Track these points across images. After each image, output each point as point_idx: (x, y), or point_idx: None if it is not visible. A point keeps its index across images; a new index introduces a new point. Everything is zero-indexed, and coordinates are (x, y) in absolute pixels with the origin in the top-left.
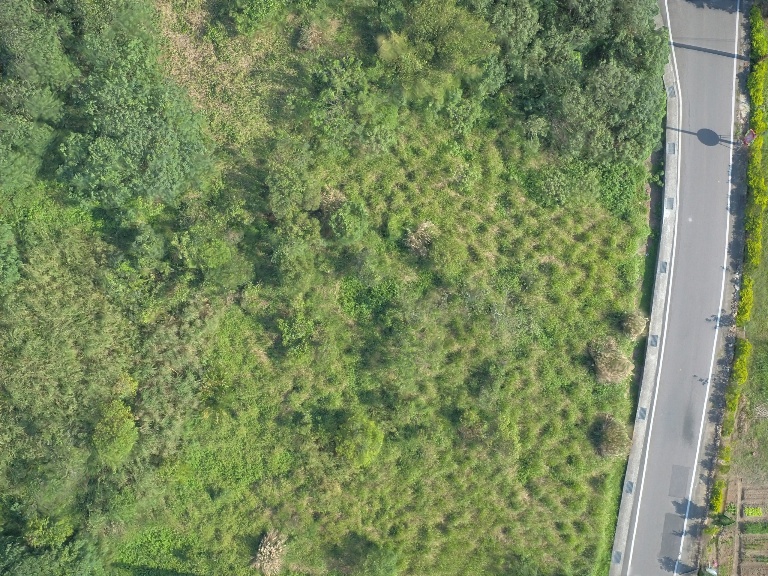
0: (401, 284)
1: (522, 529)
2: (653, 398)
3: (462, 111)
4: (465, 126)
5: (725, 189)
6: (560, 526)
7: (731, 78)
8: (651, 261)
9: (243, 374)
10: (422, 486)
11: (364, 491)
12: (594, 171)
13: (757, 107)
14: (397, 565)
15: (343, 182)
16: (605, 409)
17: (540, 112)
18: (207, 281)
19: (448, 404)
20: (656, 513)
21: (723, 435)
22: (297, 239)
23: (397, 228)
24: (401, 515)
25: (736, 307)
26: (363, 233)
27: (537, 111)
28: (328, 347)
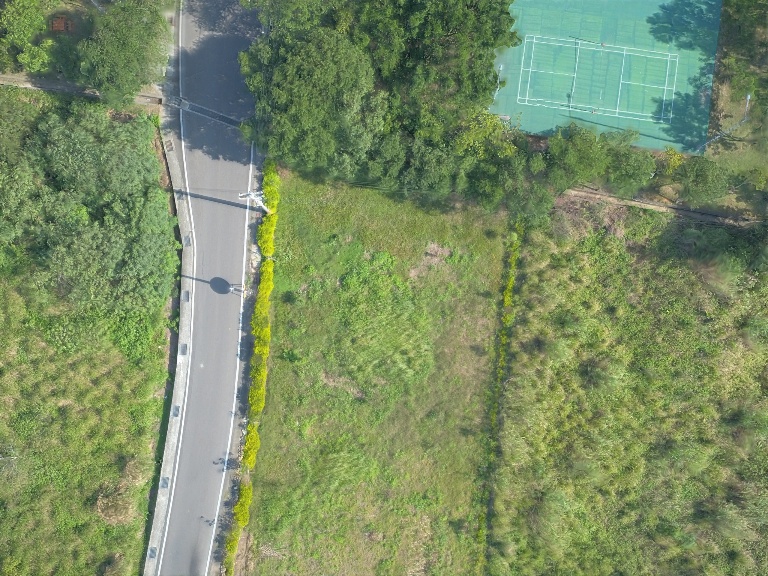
0: None
1: None
2: (163, 538)
3: None
4: None
5: (236, 336)
6: None
7: (243, 228)
8: (169, 404)
9: None
10: None
11: None
12: (111, 317)
13: (267, 257)
14: None
15: None
16: (113, 550)
17: None
18: None
19: None
20: None
21: (226, 575)
22: None
23: None
24: None
25: (242, 451)
26: None
27: None
28: None
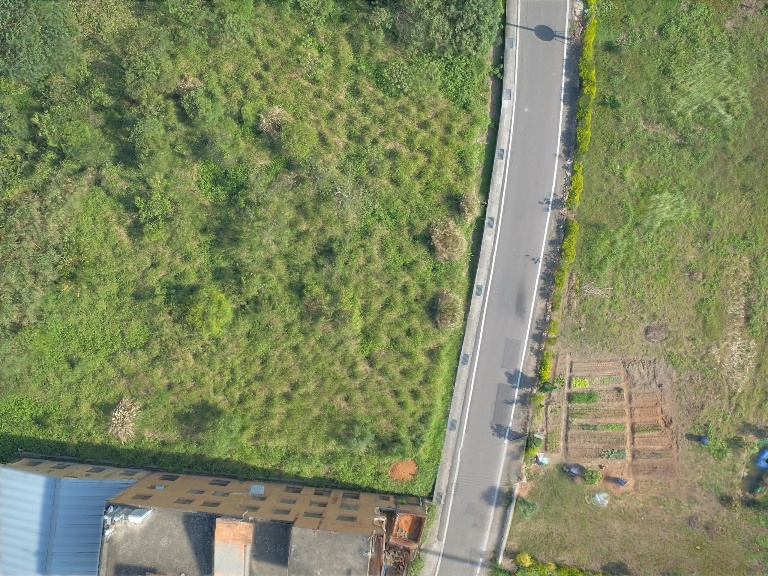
0: (255, 167)
1: (363, 397)
2: (489, 276)
3: (313, 4)
4: (317, 19)
5: (559, 81)
6: (398, 393)
7: None
8: (491, 149)
9: (104, 251)
10: (270, 356)
11: (216, 361)
12: (437, 63)
13: (590, 5)
14: (245, 430)
15: (202, 71)
16: (442, 285)
17: (386, 6)
18: (67, 159)
19: (297, 280)
20: (489, 383)
21: (552, 310)
22: (152, 119)
23: (251, 114)
24: (250, 384)
25: (567, 191)
26: (219, 119)
27: (383, 5)
28: (181, 222)
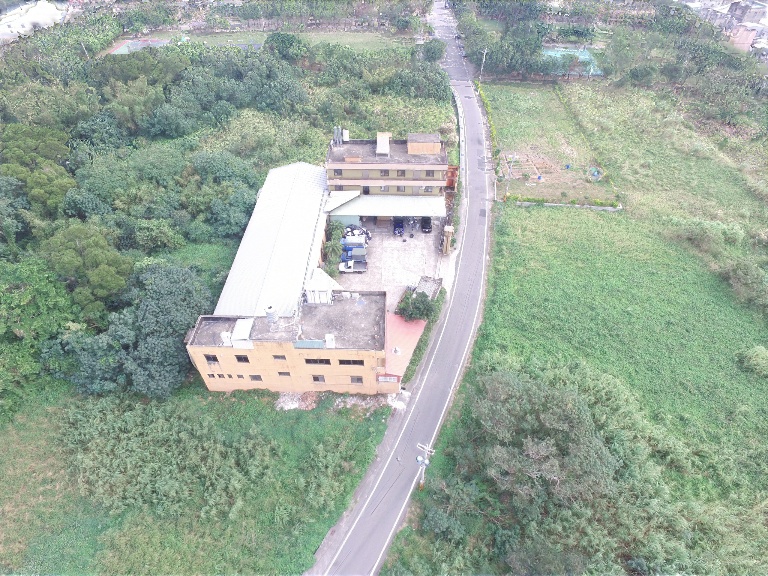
0: None
1: None
2: None
3: None
4: None
5: None
6: None
7: (471, 89)
8: None
9: None
10: None
11: None
12: None
13: None
14: None
15: None
16: None
17: None
18: None
19: None
20: (474, 159)
21: None
22: None
23: None
24: None
25: (487, 121)
26: None
27: None
28: None
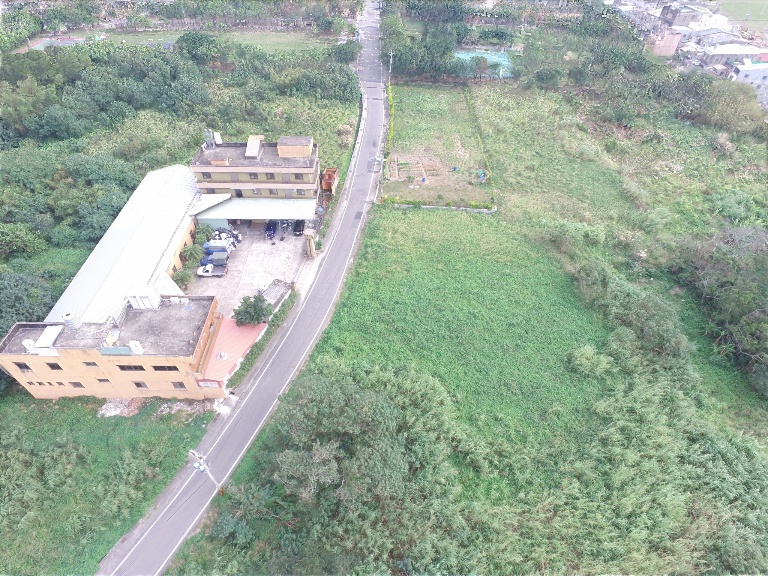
0: None
1: None
2: None
3: None
4: (298, 97)
5: (382, 106)
6: (326, 161)
7: None
8: None
9: None
10: None
11: None
12: None
13: None
14: None
15: None
16: None
17: None
18: None
19: None
20: (364, 161)
21: None
22: None
23: None
24: None
25: (388, 123)
26: None
27: None
28: (243, 126)
